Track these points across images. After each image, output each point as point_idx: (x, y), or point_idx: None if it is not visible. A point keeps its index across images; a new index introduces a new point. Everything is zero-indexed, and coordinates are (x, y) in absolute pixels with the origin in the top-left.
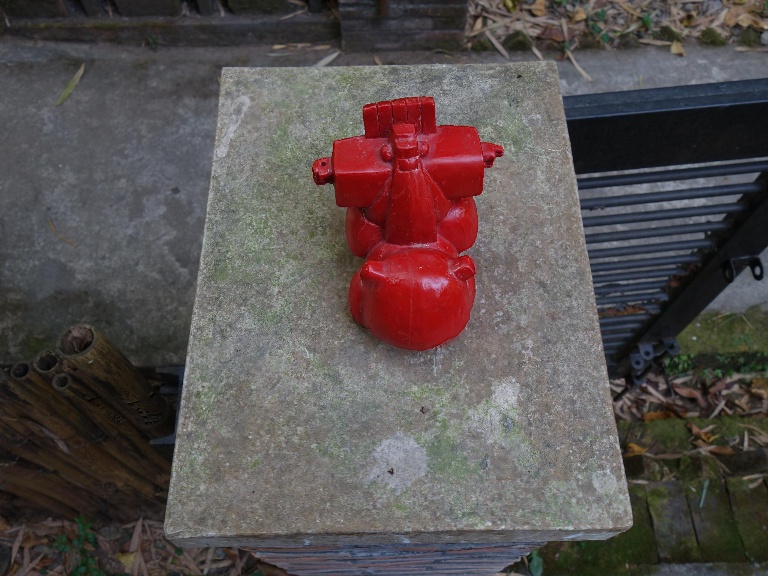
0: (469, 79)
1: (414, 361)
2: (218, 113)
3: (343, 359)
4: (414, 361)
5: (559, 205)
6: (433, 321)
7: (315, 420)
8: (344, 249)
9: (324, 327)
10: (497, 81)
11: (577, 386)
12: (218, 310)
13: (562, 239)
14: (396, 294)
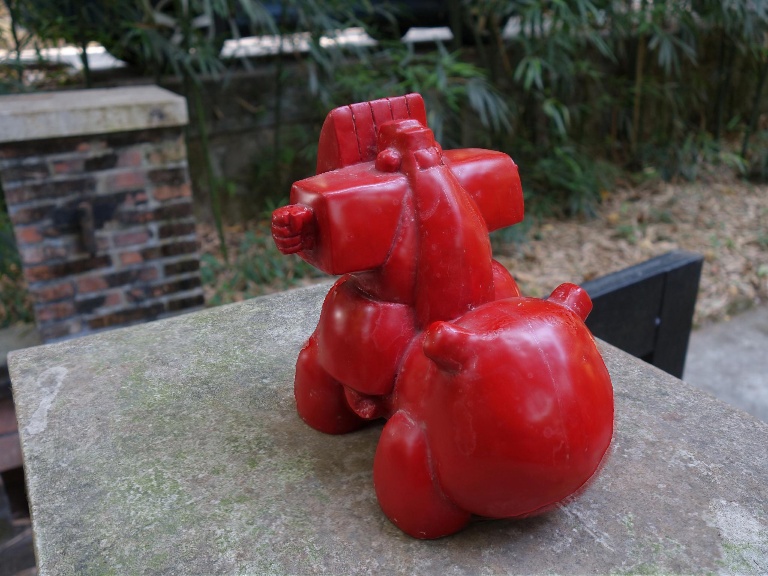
0: None
1: (560, 547)
2: (14, 393)
3: None
4: (560, 547)
5: None
6: (588, 384)
7: None
8: (319, 459)
9: (363, 570)
10: None
11: None
12: None
13: None
14: (510, 351)
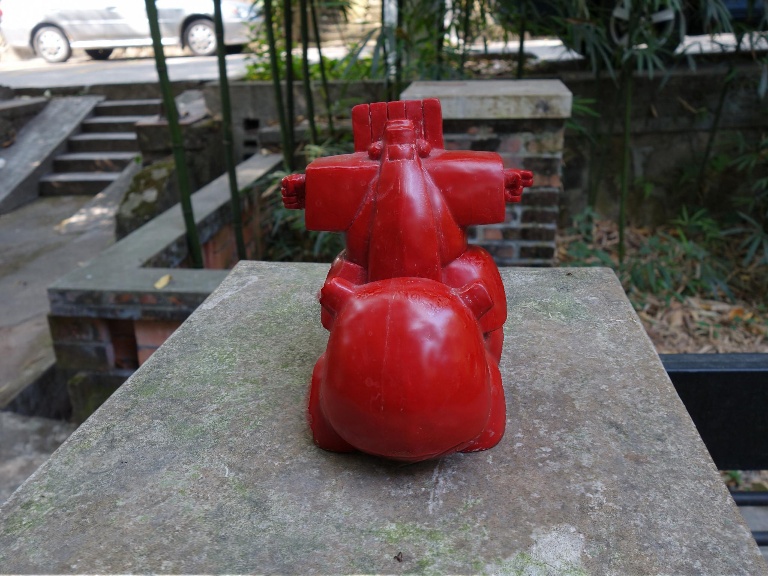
0: (509, 275)
1: (397, 493)
2: (219, 285)
3: (280, 482)
4: (397, 493)
5: (630, 359)
6: (422, 358)
7: (200, 554)
8: None
9: (265, 446)
10: (542, 277)
11: (697, 549)
12: (122, 420)
13: (639, 385)
14: (366, 311)
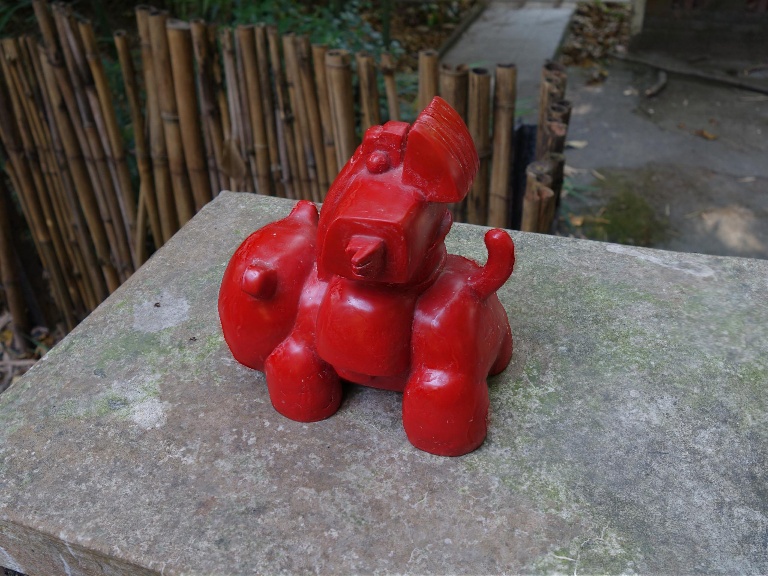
0: None
1: None
2: (683, 252)
3: None
4: None
5: None
6: None
7: None
8: None
9: None
10: None
11: (94, 494)
12: None
13: (323, 575)
14: None
